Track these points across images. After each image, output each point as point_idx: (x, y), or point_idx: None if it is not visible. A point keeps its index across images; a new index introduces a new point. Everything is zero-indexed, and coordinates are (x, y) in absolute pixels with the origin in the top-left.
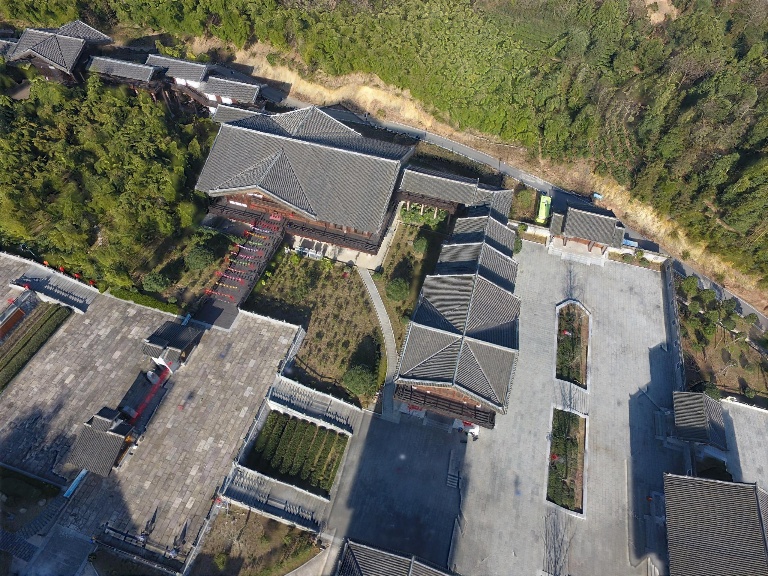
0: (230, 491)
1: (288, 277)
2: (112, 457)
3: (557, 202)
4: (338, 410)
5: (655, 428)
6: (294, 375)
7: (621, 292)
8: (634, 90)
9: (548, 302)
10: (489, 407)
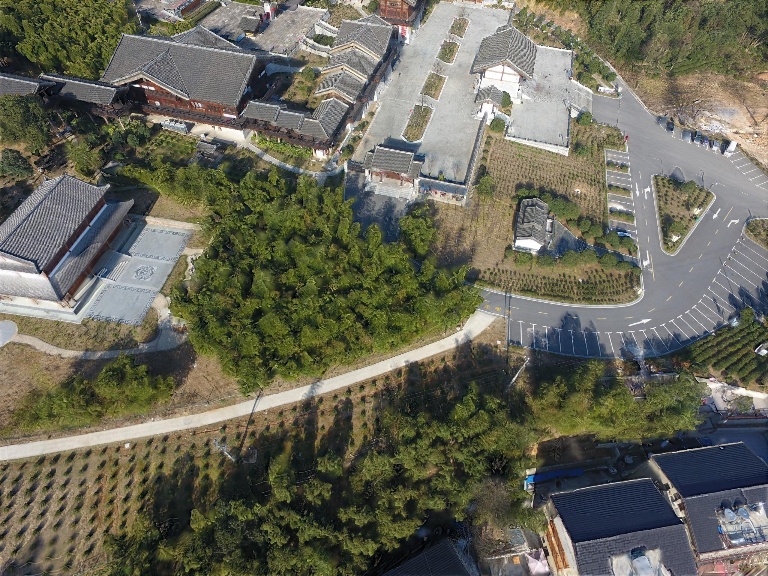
0: None
1: (319, 6)
2: (255, 25)
3: None
4: None
5: None
6: None
7: (488, 16)
8: None
9: (450, 18)
10: (408, 2)
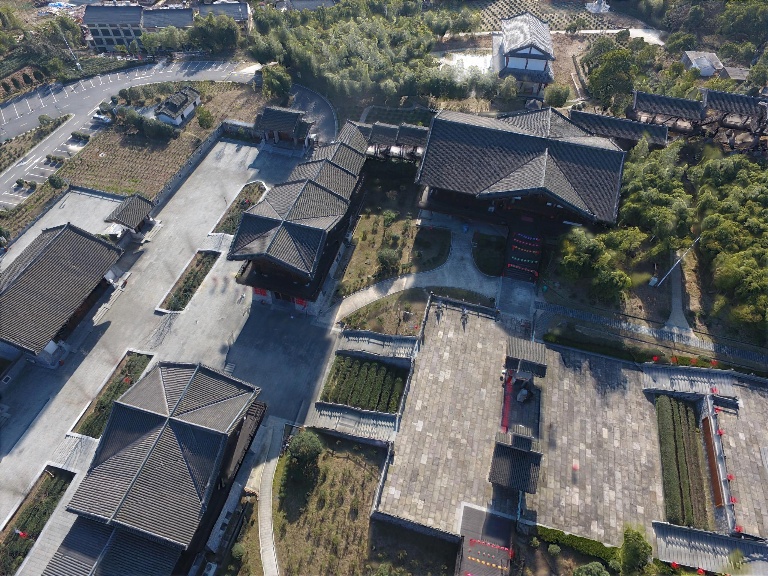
0: (413, 343)
1: None
2: (510, 346)
3: None
4: (329, 422)
5: (3, 425)
6: (377, 455)
7: None
8: None
9: None
10: None
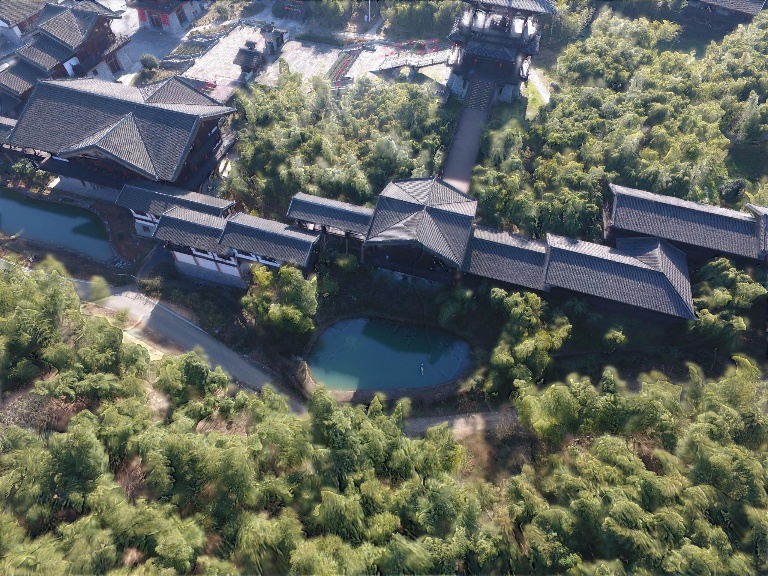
0: None
1: None
2: None
3: None
4: None
5: None
6: None
7: None
8: None
9: None
10: None
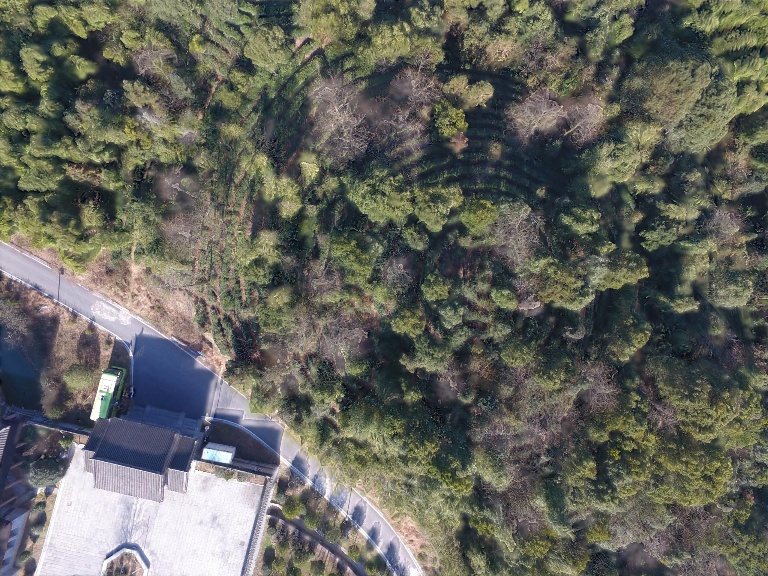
0: None
1: None
2: None
3: (144, 362)
4: None
5: None
6: None
7: (199, 526)
8: (292, 112)
9: (97, 552)
10: None
